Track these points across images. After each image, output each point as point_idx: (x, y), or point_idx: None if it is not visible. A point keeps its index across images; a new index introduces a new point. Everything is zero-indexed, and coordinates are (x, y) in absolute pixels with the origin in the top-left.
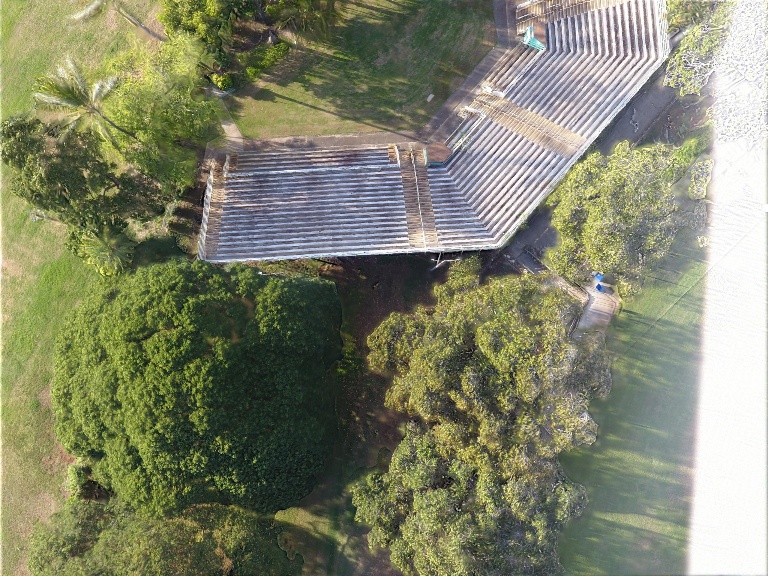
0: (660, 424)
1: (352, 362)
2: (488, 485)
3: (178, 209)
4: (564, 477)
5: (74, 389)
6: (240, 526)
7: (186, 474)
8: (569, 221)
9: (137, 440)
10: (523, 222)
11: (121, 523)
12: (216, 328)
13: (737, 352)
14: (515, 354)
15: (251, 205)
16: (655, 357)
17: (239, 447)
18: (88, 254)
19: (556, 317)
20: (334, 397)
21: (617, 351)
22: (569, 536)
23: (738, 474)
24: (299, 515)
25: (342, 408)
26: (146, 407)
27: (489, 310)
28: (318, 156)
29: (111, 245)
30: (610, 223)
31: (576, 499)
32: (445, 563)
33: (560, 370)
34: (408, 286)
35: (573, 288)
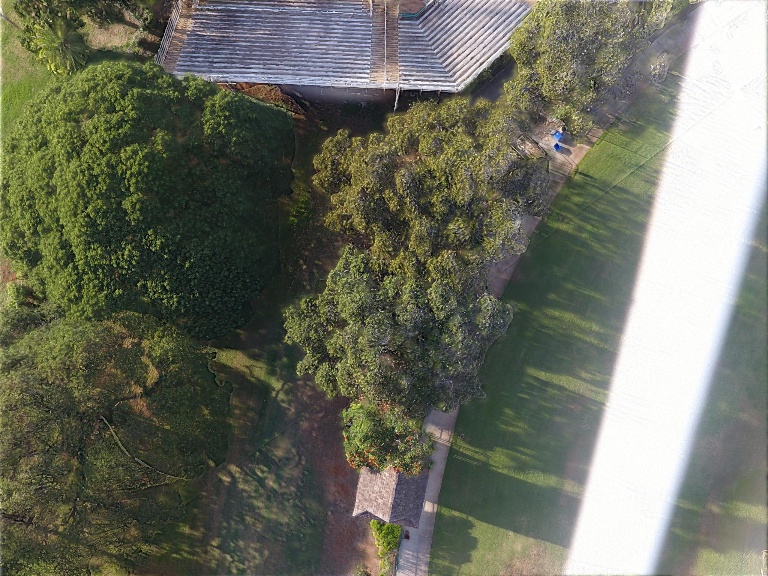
0: (604, 291)
1: (305, 211)
2: (413, 289)
3: (144, 41)
4: (491, 292)
5: (13, 179)
6: (170, 339)
7: (118, 276)
8: (525, 45)
9: (69, 227)
10: (486, 69)
11: (50, 324)
12: (159, 121)
13: (689, 229)
14: (453, 157)
15: (216, 34)
16: (606, 224)
17: (172, 246)
18: (40, 45)
19: (498, 126)
20: (278, 226)
21: (568, 213)
22: (501, 390)
23: (677, 350)
24: (237, 358)
25: (290, 256)
26: (79, 187)
27: (435, 126)
28: (291, 0)
29: (65, 42)
30: (562, 35)
31: (500, 312)
32: (363, 365)
33: (494, 170)
34: (368, 139)
35: (531, 145)
